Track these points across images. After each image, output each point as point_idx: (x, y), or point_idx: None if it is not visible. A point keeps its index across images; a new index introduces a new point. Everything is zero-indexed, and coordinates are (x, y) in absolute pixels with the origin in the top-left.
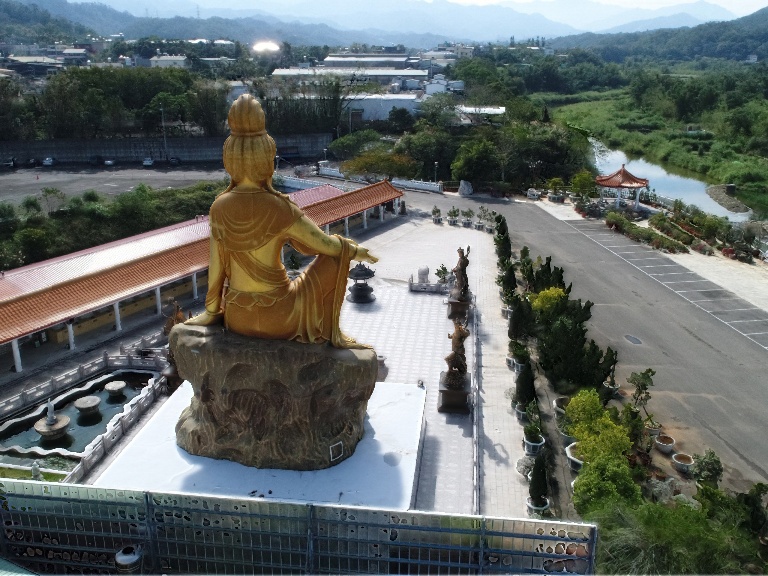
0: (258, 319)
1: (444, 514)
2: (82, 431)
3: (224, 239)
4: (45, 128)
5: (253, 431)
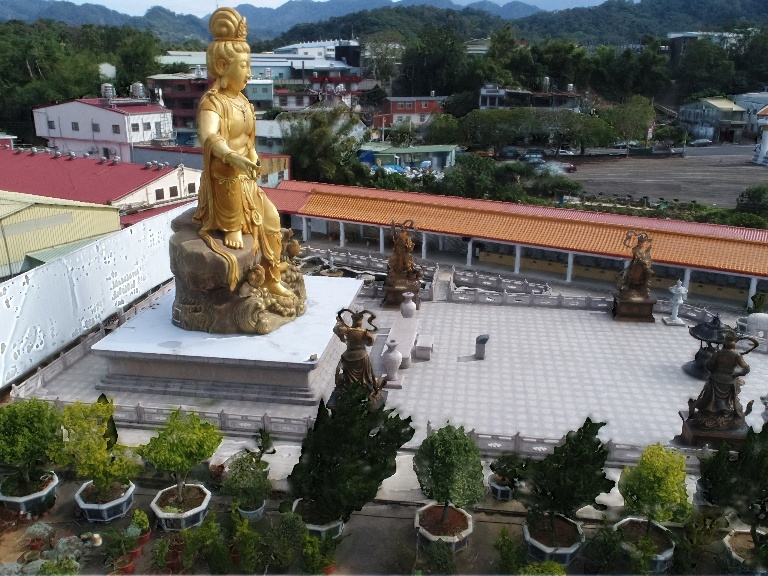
0: None
1: None
2: None
3: None
4: None
5: None
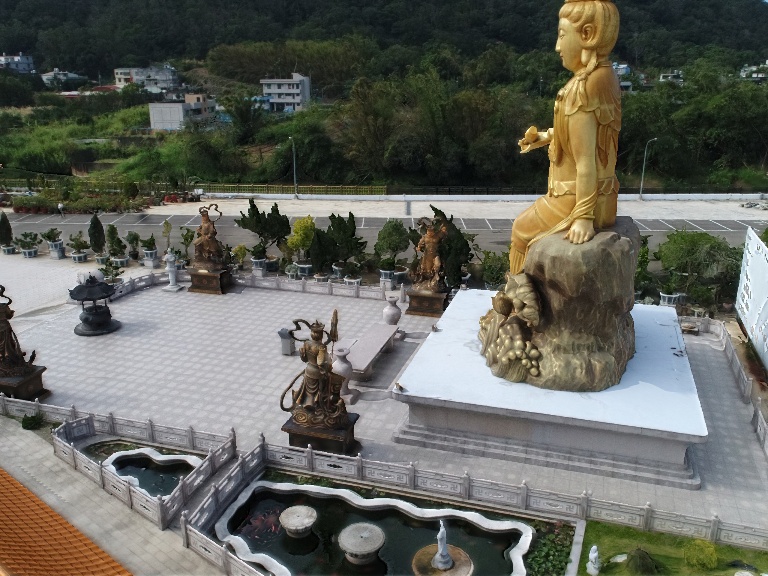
0: None
1: None
2: (402, 575)
3: None
4: None
5: None
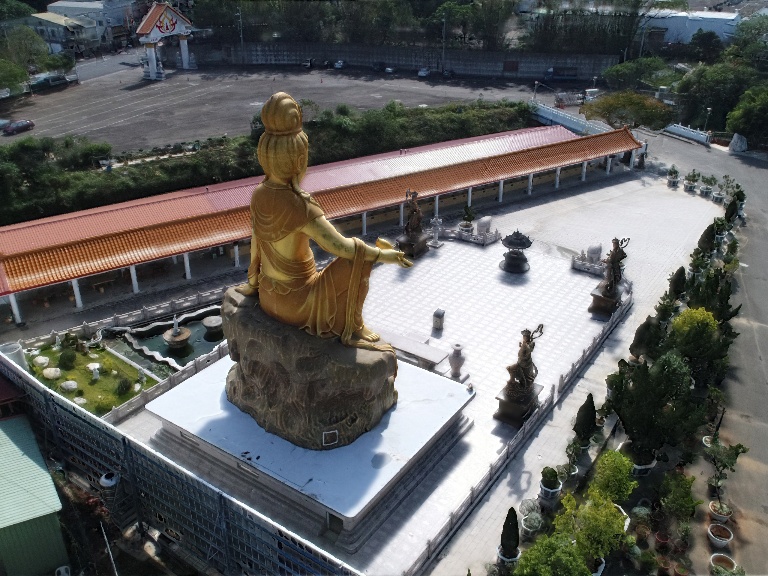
0: (276, 303)
1: (313, 546)
2: (203, 345)
3: (254, 226)
4: (342, 32)
5: (267, 398)
